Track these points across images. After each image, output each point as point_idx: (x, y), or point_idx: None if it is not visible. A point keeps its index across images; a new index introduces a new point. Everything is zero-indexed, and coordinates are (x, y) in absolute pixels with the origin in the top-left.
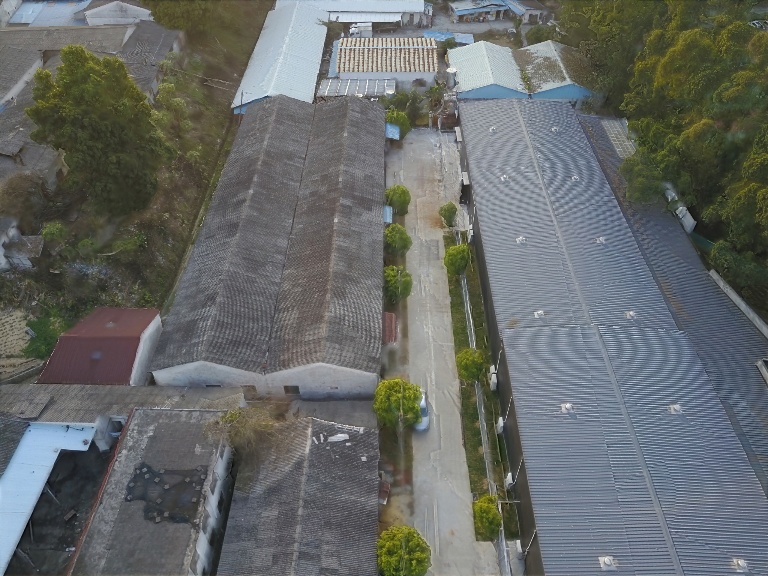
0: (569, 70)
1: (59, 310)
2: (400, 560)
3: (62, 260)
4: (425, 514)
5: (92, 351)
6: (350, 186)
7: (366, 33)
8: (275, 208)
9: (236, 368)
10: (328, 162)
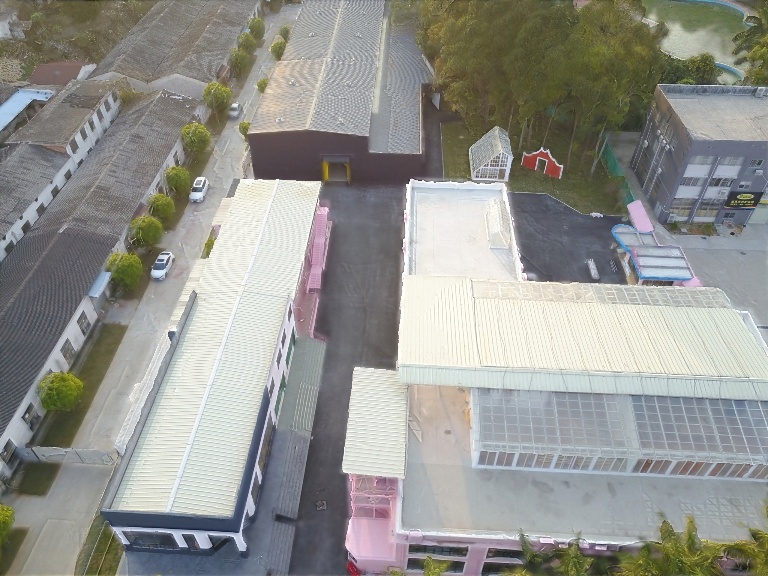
0: None
1: (39, 63)
2: (190, 130)
3: (43, 39)
4: (222, 143)
5: (55, 71)
6: (224, 15)
7: None
8: (175, 24)
9: (131, 78)
10: (215, 5)
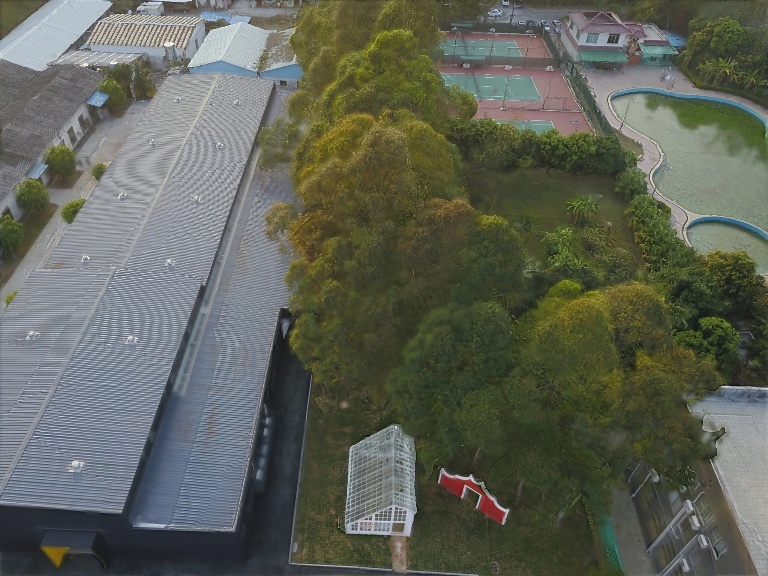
0: None
1: None
2: None
3: None
4: None
5: None
6: (5, 143)
7: (152, 11)
8: None
9: None
10: (2, 122)
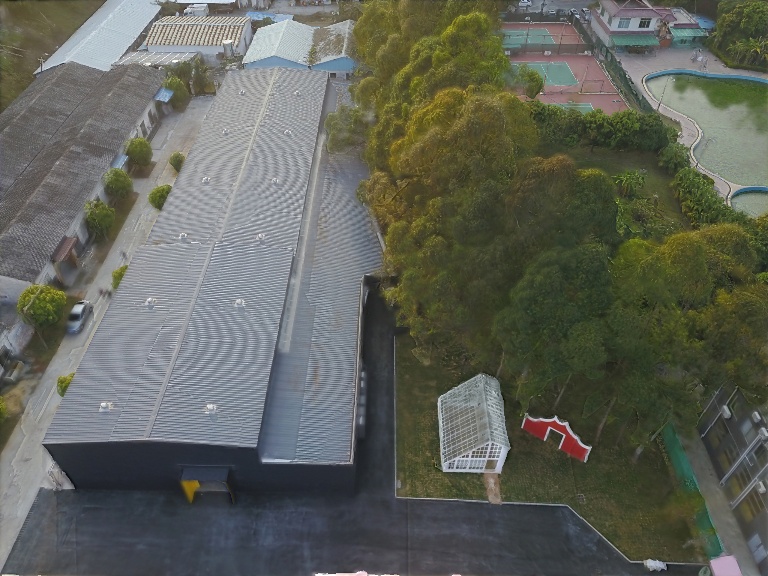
0: (351, 45)
1: None
2: None
3: None
4: (42, 393)
5: None
6: (89, 137)
7: (199, 13)
8: (15, 154)
9: None
10: (82, 117)
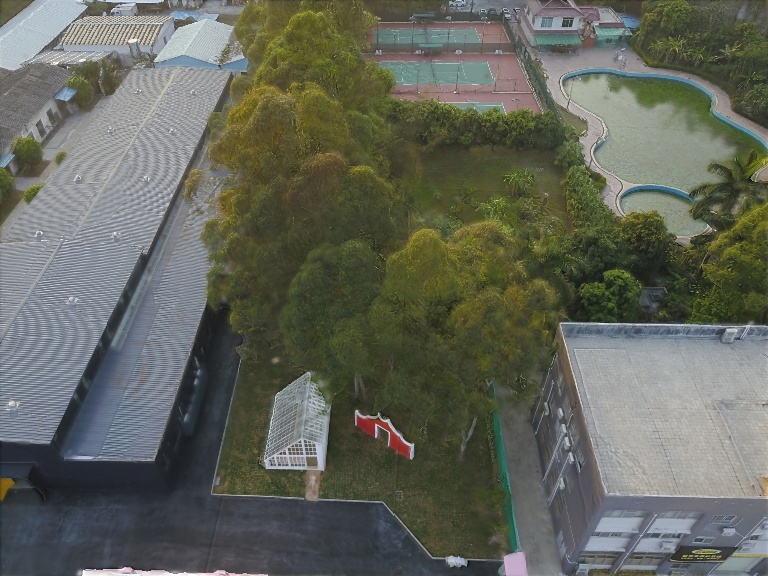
0: None
1: None
2: None
3: None
4: None
5: None
6: None
7: (126, 13)
8: None
9: None
10: None
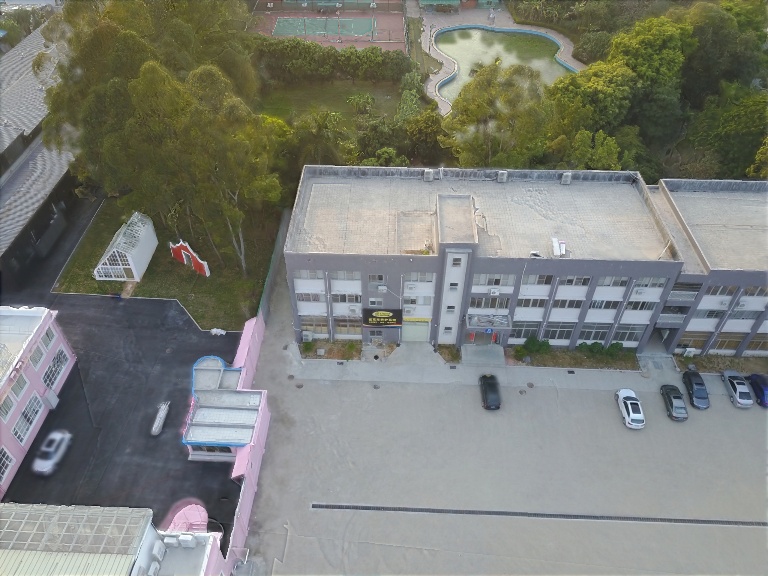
0: None
1: None
2: None
3: None
4: None
5: None
6: None
7: None
8: None
9: None
10: None
